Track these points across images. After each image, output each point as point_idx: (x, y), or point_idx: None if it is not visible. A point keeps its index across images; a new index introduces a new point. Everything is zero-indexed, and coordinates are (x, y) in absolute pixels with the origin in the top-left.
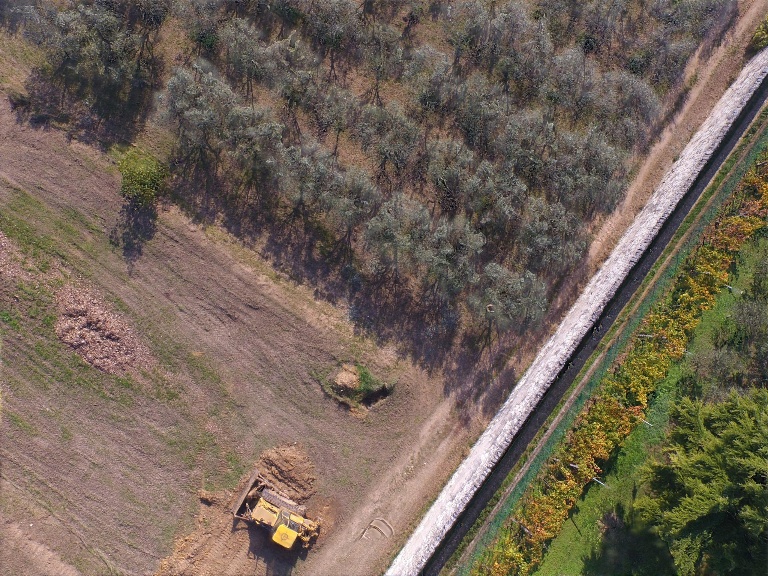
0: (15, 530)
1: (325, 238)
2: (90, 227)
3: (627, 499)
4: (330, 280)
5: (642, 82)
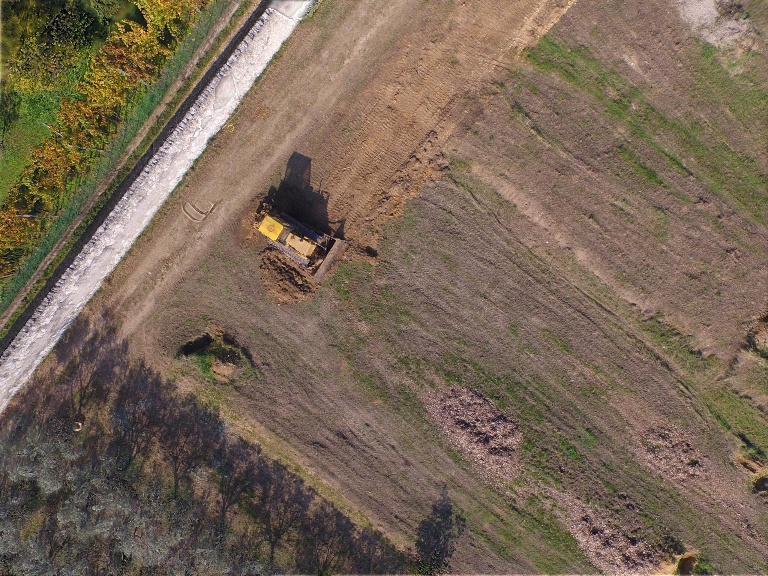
0: (562, 240)
1: (249, 506)
2: (485, 537)
3: None
4: (245, 463)
5: None
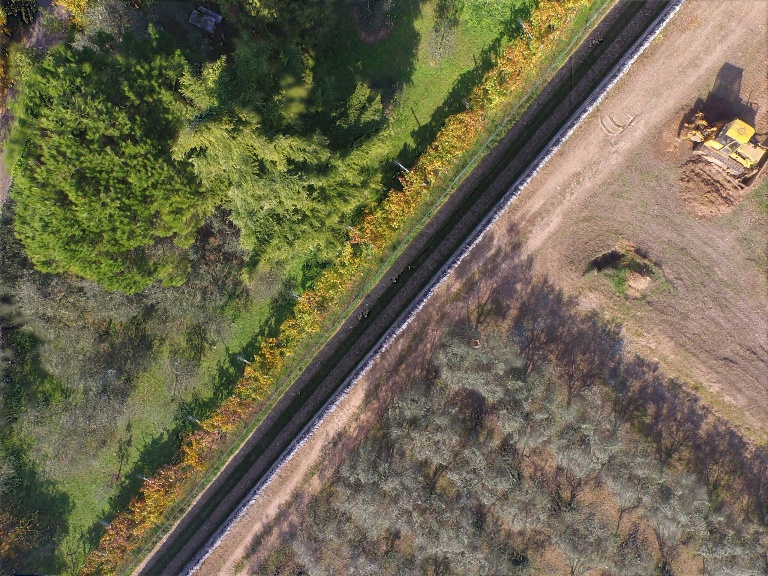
0: None
1: (641, 425)
2: None
3: (359, 142)
4: (639, 381)
5: (294, 568)
